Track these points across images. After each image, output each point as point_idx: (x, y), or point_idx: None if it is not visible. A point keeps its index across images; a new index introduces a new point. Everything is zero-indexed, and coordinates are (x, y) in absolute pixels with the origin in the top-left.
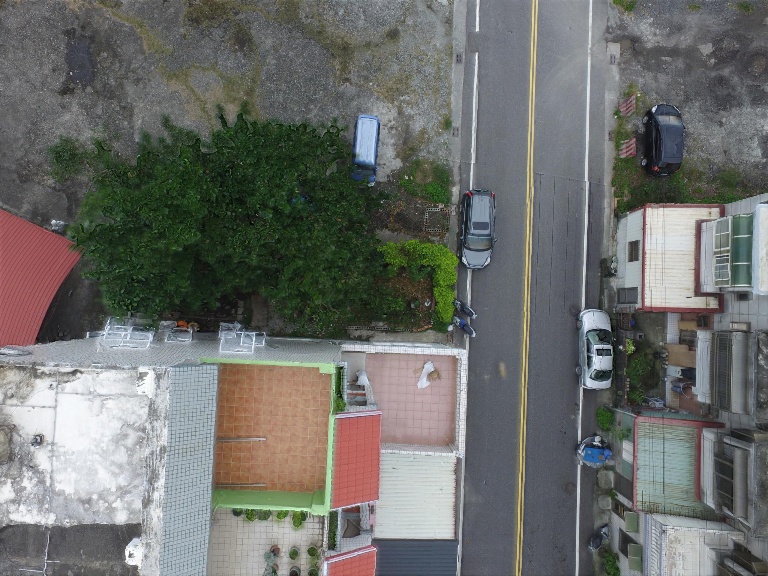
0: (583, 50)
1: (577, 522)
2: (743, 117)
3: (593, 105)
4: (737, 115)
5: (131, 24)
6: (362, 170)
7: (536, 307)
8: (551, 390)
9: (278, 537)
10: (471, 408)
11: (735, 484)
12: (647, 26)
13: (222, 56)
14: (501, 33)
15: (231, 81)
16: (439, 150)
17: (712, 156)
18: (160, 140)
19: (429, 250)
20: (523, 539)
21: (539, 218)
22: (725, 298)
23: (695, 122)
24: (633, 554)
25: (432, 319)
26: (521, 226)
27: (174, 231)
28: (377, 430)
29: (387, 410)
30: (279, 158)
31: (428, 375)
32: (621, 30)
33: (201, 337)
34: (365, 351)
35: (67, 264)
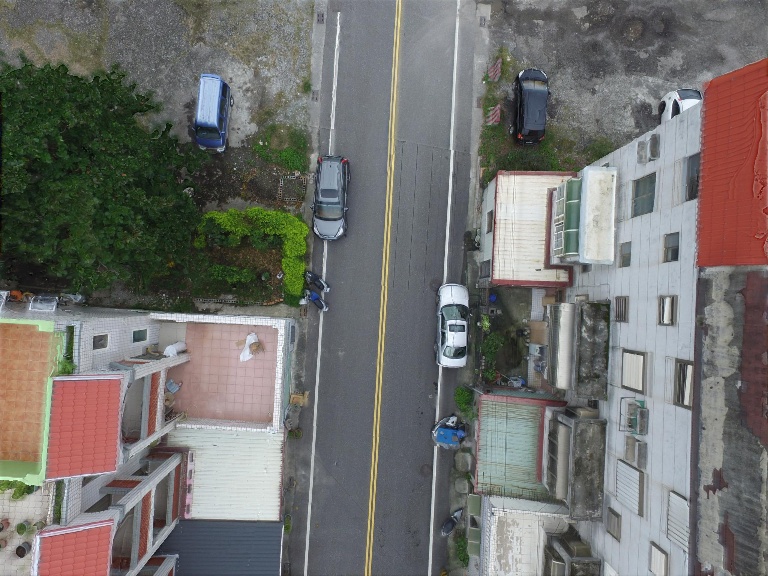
0: (451, 11)
1: (432, 506)
2: (617, 84)
3: (460, 70)
4: (611, 82)
5: None
6: (207, 133)
7: (394, 281)
8: (408, 368)
9: (9, 511)
10: (324, 386)
11: (558, 464)
12: None
13: (68, 12)
14: None
15: (77, 38)
16: (297, 115)
17: (583, 125)
18: None
19: (272, 218)
20: (374, 523)
21: (400, 188)
22: (574, 271)
23: (567, 89)
24: (472, 538)
25: (283, 292)
26: (381, 196)
27: None
28: (116, 396)
29: (207, 384)
30: (41, 103)
31: (249, 347)
32: None
33: (10, 304)
34: (175, 320)
35: None
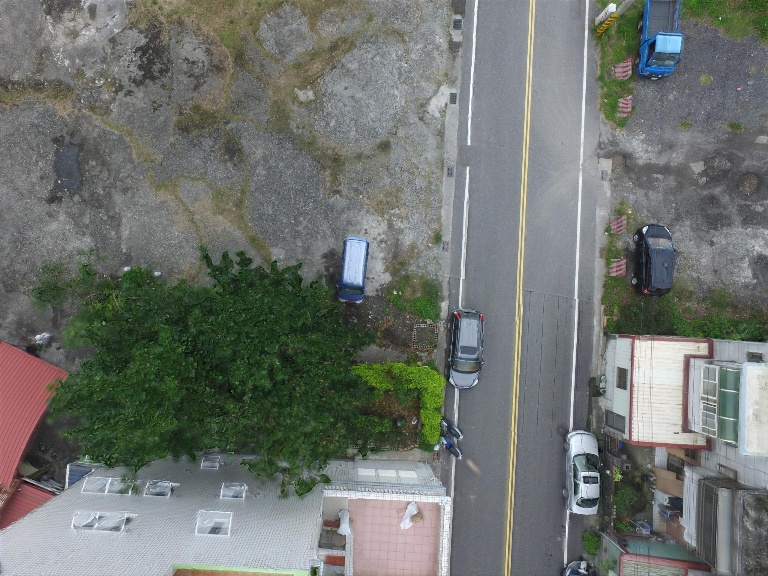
0: (575, 166)
1: None
2: (734, 237)
3: (584, 221)
4: (728, 234)
5: (121, 132)
6: (350, 290)
7: (523, 426)
8: (537, 511)
9: None
10: (456, 529)
11: None
12: (639, 142)
13: (212, 166)
14: (493, 147)
15: (220, 192)
16: (428, 265)
17: (702, 276)
18: (147, 251)
19: (416, 375)
20: None
21: (528, 336)
22: None
23: (686, 241)
24: None
25: (418, 439)
26: (510, 344)
27: (151, 417)
28: None
29: (369, 550)
30: (260, 330)
31: (411, 517)
32: (613, 146)
33: (182, 473)
34: (347, 497)
35: (49, 392)
